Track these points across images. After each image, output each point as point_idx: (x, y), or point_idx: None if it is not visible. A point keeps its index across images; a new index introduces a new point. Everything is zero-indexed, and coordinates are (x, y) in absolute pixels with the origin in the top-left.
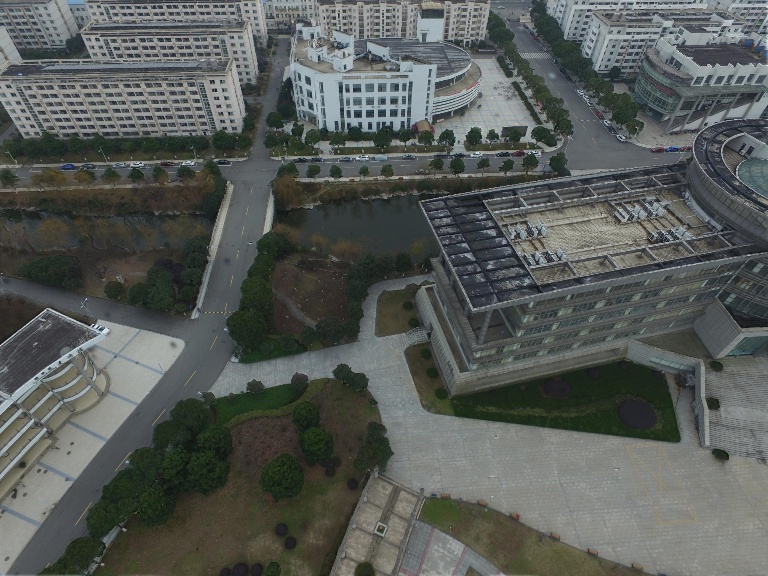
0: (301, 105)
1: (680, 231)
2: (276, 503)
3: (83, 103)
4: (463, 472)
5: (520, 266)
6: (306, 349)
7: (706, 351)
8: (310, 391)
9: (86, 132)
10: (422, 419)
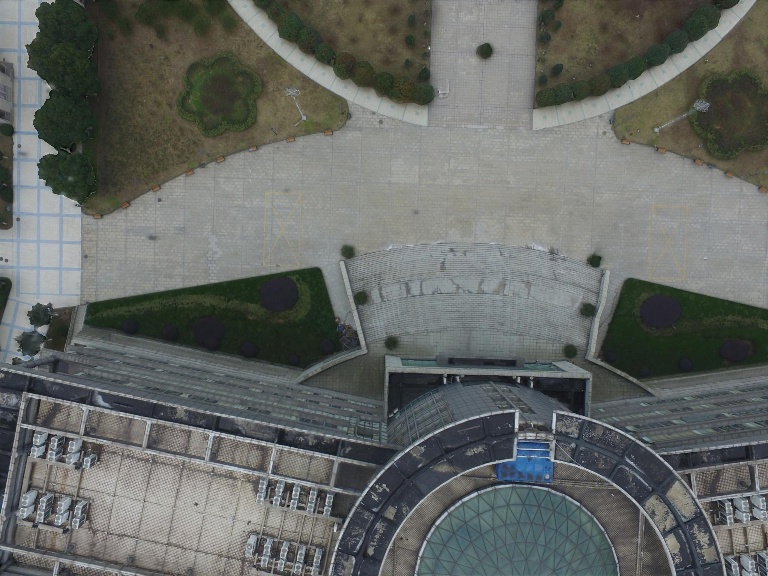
0: None
1: None
2: None
3: None
4: None
5: None
6: None
7: None
8: None
9: None
10: None
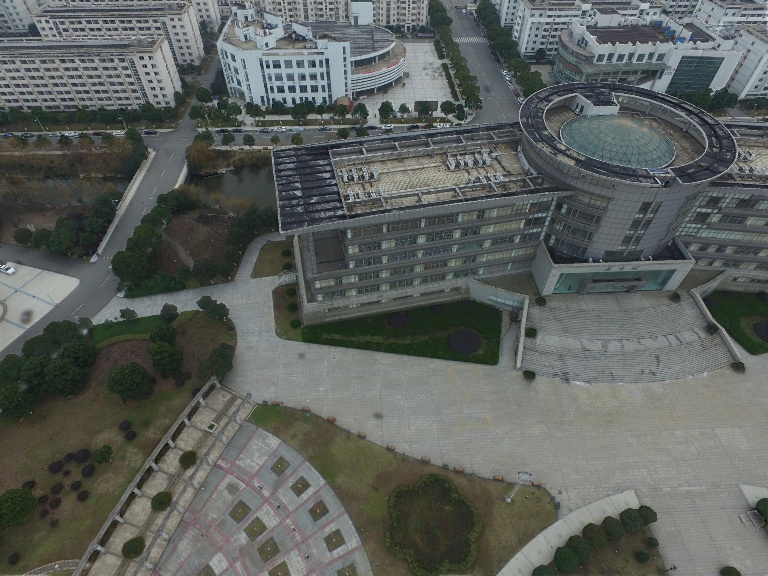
0: (231, 82)
1: (497, 176)
2: (127, 406)
3: (24, 77)
4: (297, 385)
5: (339, 201)
6: (185, 287)
7: (536, 289)
8: (179, 320)
9: (30, 105)
10: (273, 344)
